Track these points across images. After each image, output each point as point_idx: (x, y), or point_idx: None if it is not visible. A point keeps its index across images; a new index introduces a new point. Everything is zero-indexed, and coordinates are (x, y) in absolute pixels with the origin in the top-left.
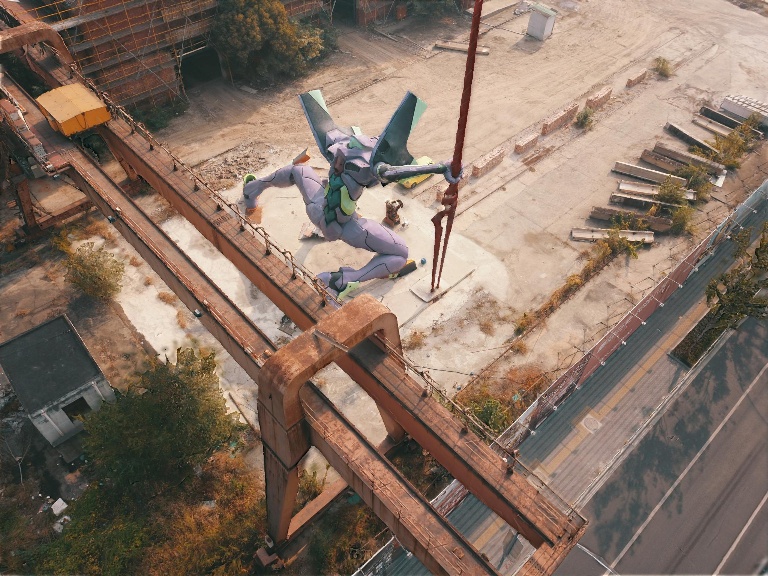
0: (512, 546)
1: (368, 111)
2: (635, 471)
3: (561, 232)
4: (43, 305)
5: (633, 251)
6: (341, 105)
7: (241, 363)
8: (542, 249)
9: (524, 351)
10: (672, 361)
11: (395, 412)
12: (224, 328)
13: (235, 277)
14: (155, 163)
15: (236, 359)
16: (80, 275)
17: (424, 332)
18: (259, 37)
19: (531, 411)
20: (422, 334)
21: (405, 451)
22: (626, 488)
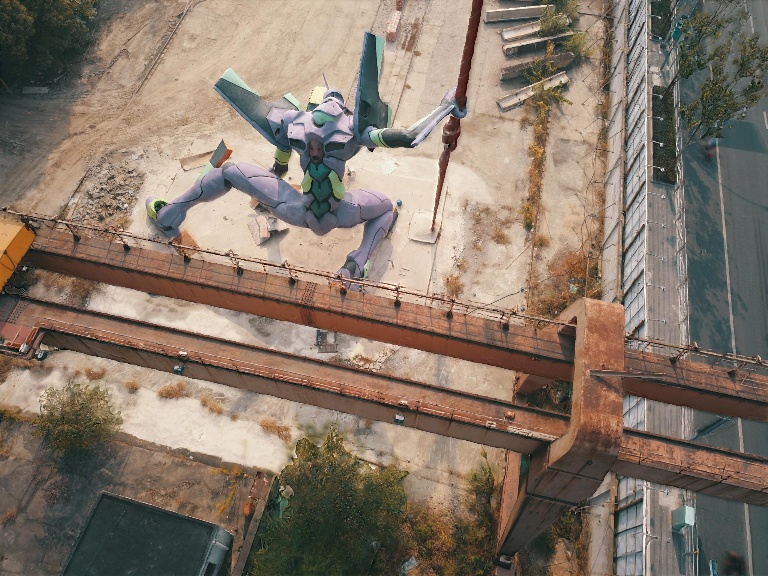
0: (717, 427)
1: (204, 58)
2: (698, 297)
3: (489, 108)
4: (26, 491)
5: (563, 98)
6: (167, 63)
7: (463, 437)
8: (486, 134)
9: (547, 242)
10: (658, 186)
11: (642, 391)
12: (443, 417)
13: (226, 325)
14: (152, 265)
15: (451, 435)
16: (72, 435)
17: (453, 274)
18: (31, 18)
19: (640, 301)
20: (453, 277)
21: (529, 396)
22: (702, 315)
